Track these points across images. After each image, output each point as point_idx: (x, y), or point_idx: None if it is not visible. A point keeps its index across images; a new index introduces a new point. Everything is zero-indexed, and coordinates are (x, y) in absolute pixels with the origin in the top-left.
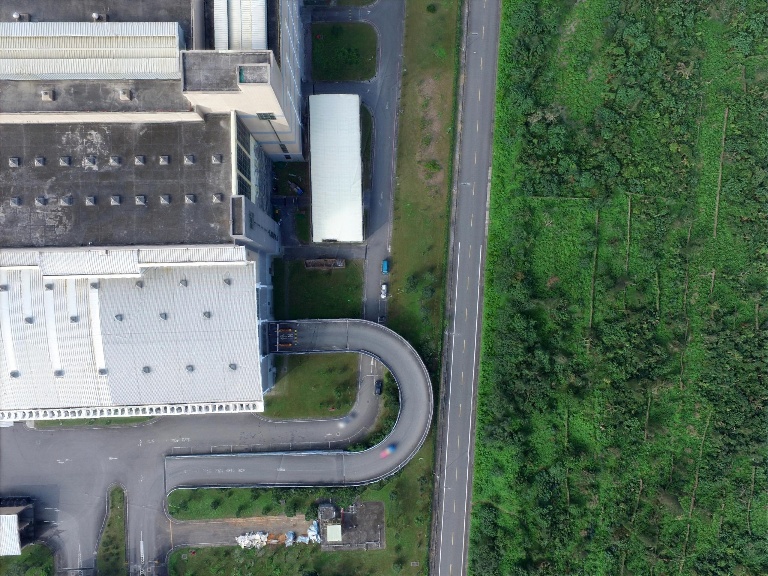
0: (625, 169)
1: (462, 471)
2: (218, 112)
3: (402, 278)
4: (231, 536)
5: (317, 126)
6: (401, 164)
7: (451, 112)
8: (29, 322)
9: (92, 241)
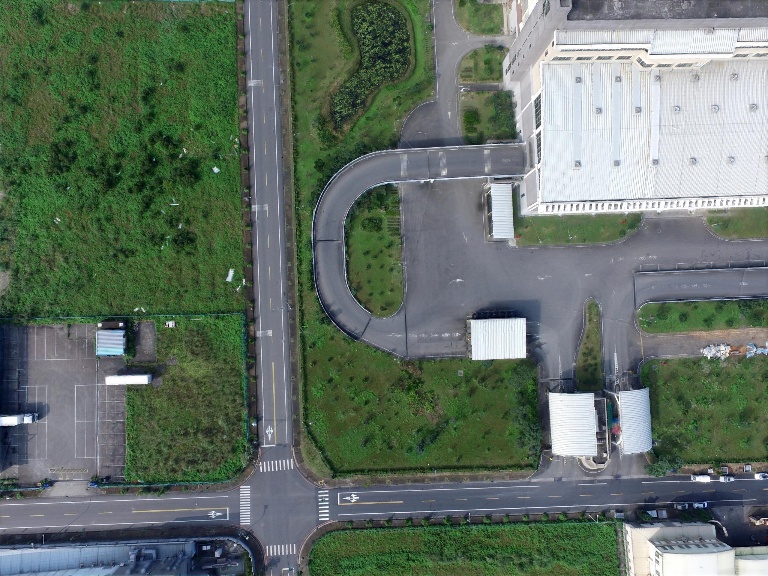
0: None
1: None
2: None
3: None
4: (696, 348)
5: None
6: None
7: None
8: None
9: None
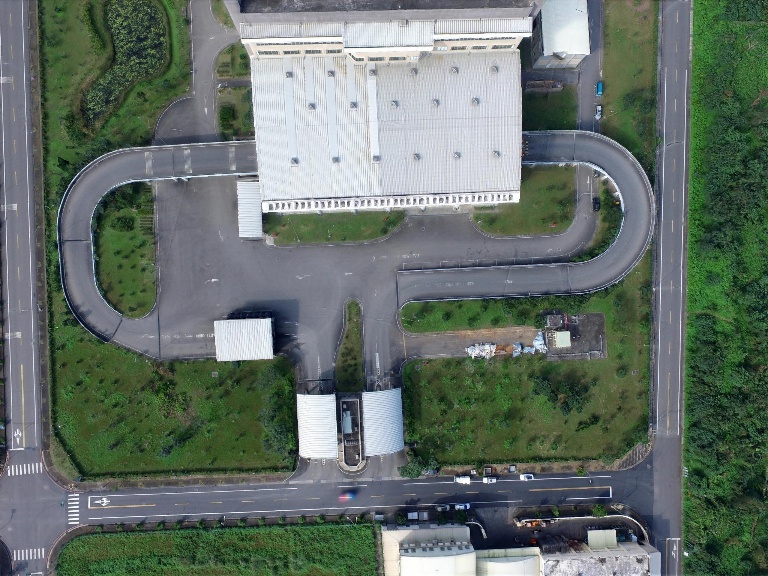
0: None
1: (676, 284)
2: None
3: (614, 100)
4: (461, 347)
5: None
6: None
7: None
8: (313, 107)
9: (400, 6)
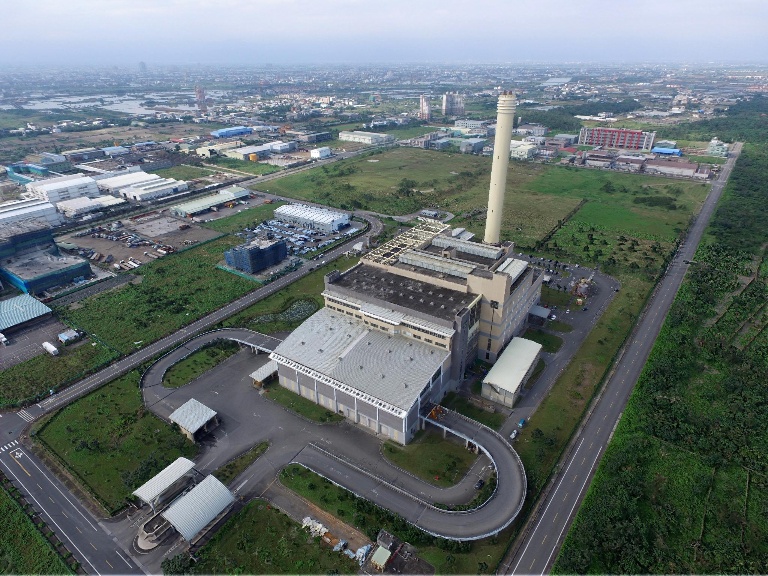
0: (741, 449)
1: None
2: (475, 293)
3: None
4: (302, 515)
5: (512, 346)
6: (556, 388)
7: None
8: (330, 329)
9: None
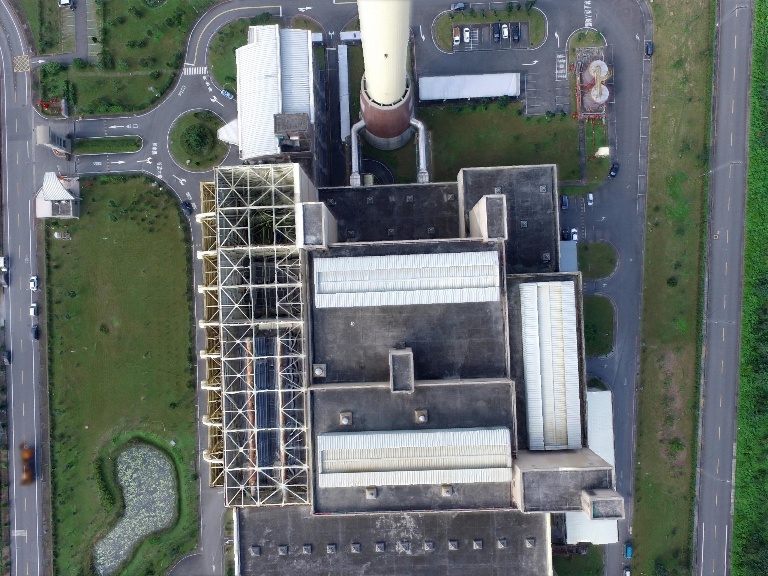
0: None
1: None
2: None
3: (645, 561)
4: None
5: None
6: (641, 442)
7: (693, 387)
8: None
9: None
